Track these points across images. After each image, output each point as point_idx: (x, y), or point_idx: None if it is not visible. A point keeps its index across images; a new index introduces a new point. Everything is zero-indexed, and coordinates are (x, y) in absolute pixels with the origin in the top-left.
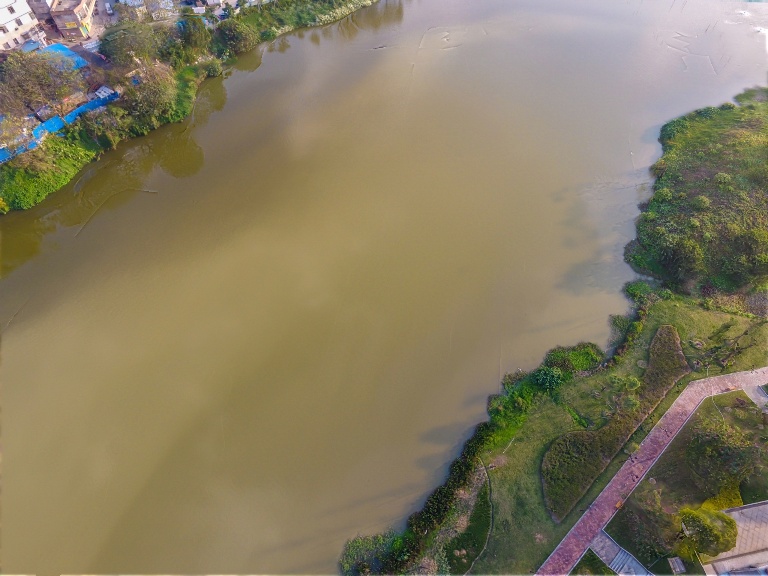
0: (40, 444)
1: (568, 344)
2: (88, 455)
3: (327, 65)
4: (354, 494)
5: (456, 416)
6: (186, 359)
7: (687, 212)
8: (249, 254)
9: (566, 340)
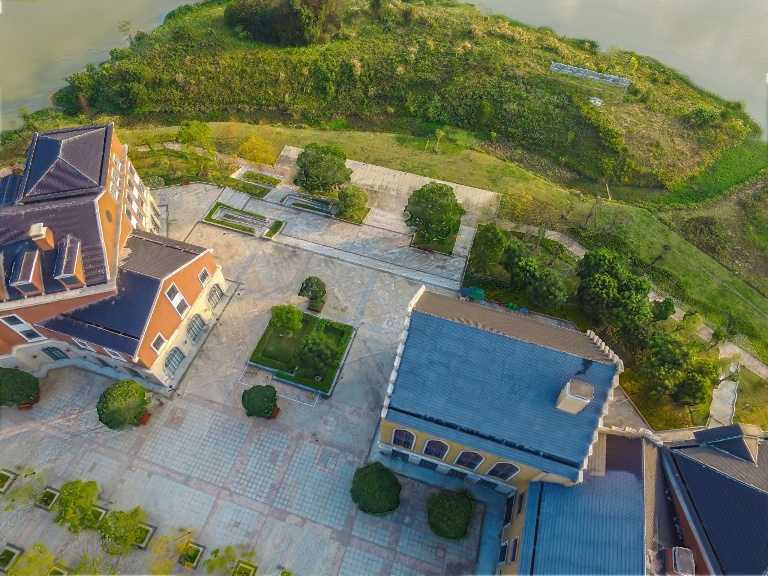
0: None
1: None
2: None
3: None
4: None
5: None
6: None
7: None
8: None
9: None
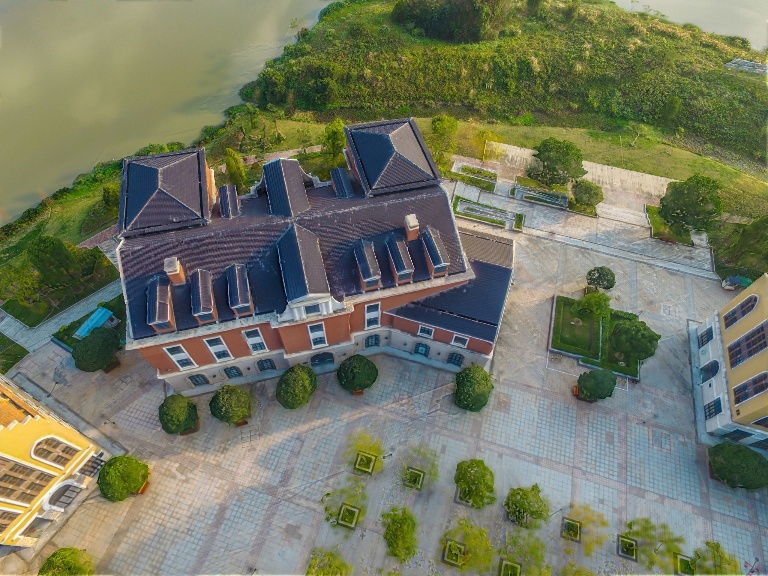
0: None
1: None
2: None
3: None
4: None
5: (47, 187)
6: None
7: None
8: None
9: (161, 141)
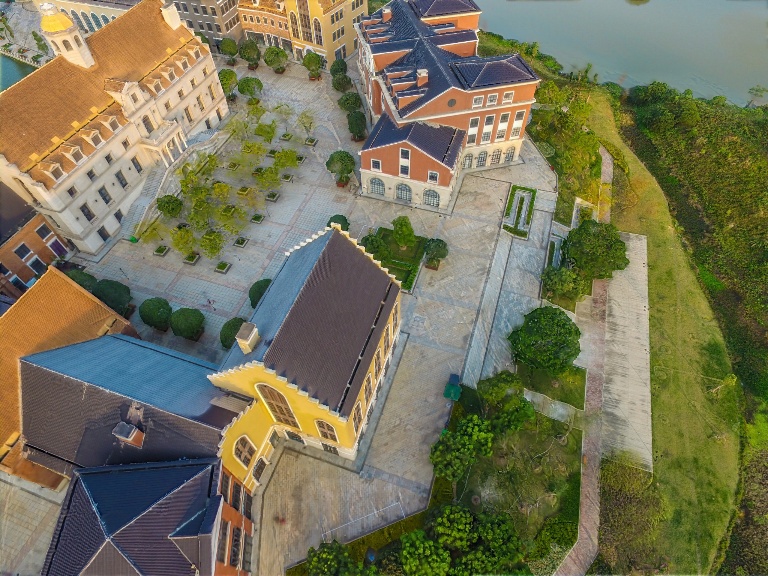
0: None
1: (559, 61)
2: None
3: None
4: None
5: None
6: None
7: None
8: None
9: (561, 61)
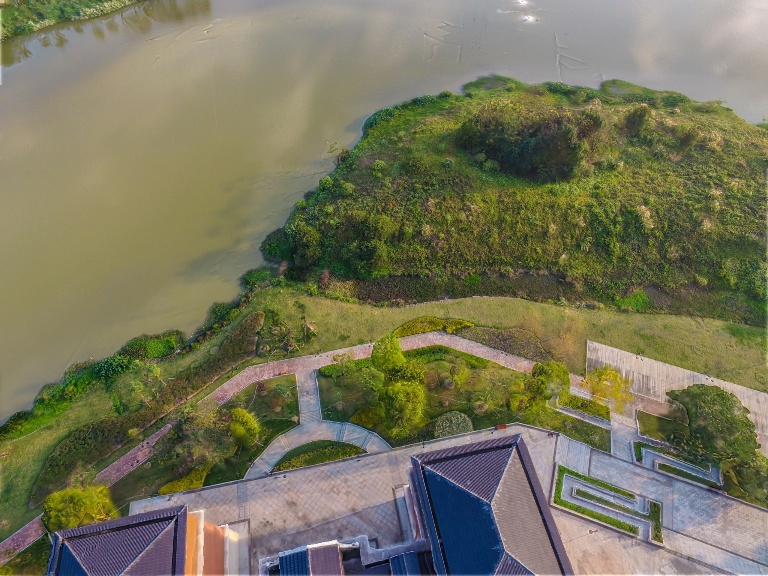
0: None
1: (155, 332)
2: None
3: (73, 59)
4: None
5: (0, 406)
6: None
7: (336, 199)
8: None
9: (155, 328)
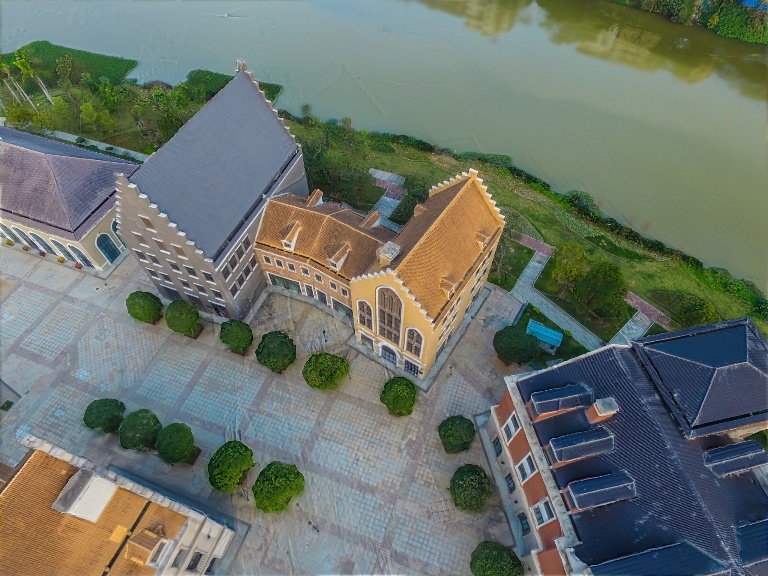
0: (585, 78)
1: None
2: (587, 94)
3: None
4: (615, 195)
5: (696, 248)
6: (659, 115)
7: None
8: (760, 130)
9: None
